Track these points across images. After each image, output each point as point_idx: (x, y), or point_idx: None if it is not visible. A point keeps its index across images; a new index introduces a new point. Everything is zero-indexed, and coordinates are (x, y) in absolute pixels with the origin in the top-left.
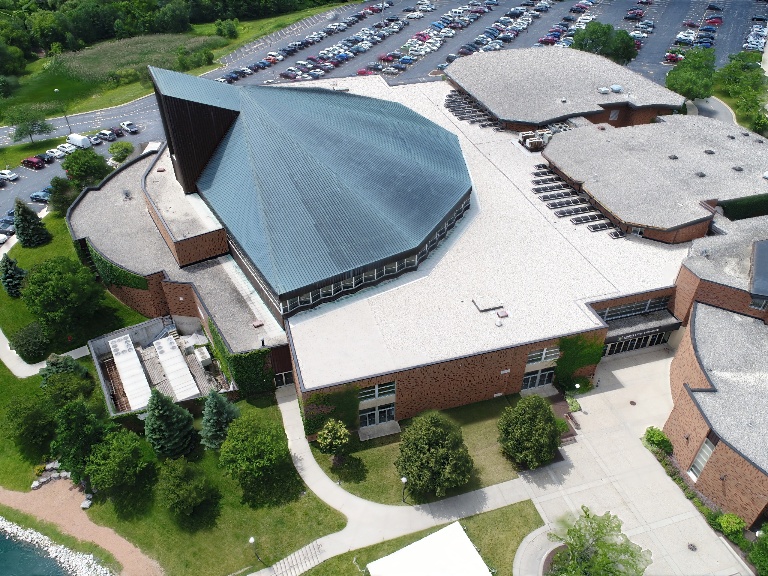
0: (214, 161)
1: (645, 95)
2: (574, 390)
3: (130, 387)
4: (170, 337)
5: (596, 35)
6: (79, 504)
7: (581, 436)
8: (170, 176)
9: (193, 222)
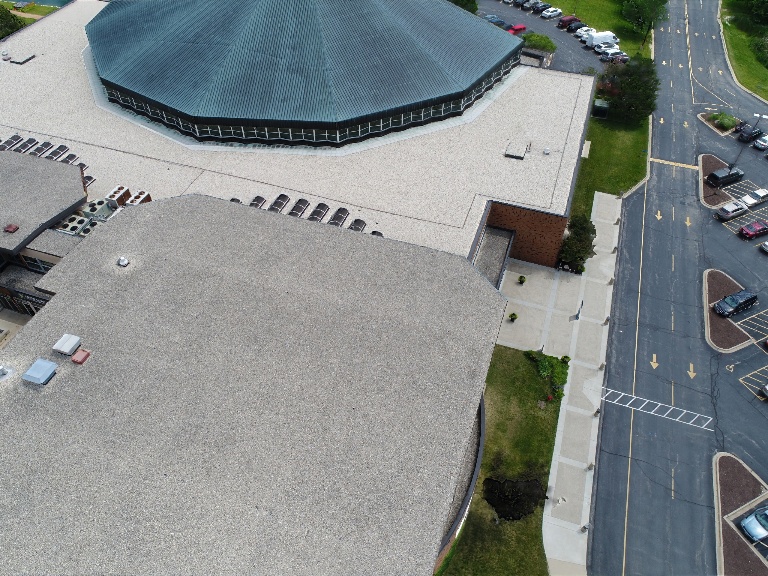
0: None
1: None
2: None
3: None
4: None
5: None
6: None
7: None
8: None
9: None
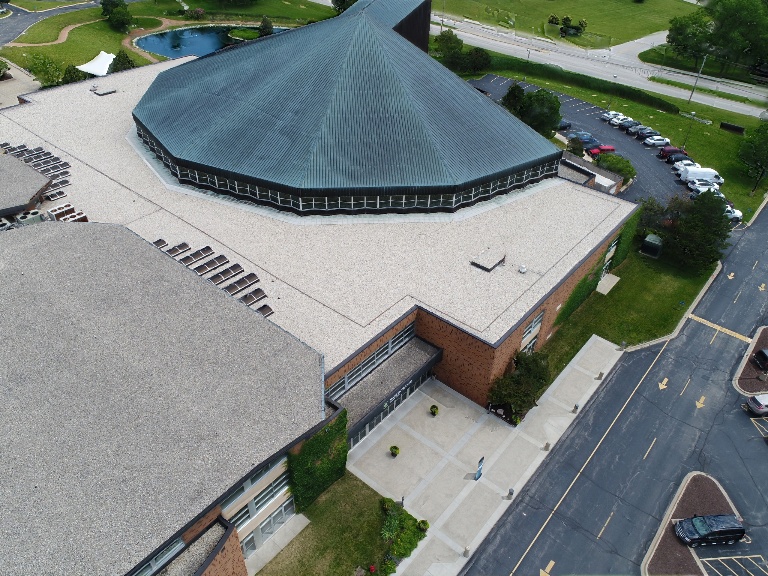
0: None
1: None
2: None
3: None
4: None
5: None
6: None
7: None
8: None
9: None
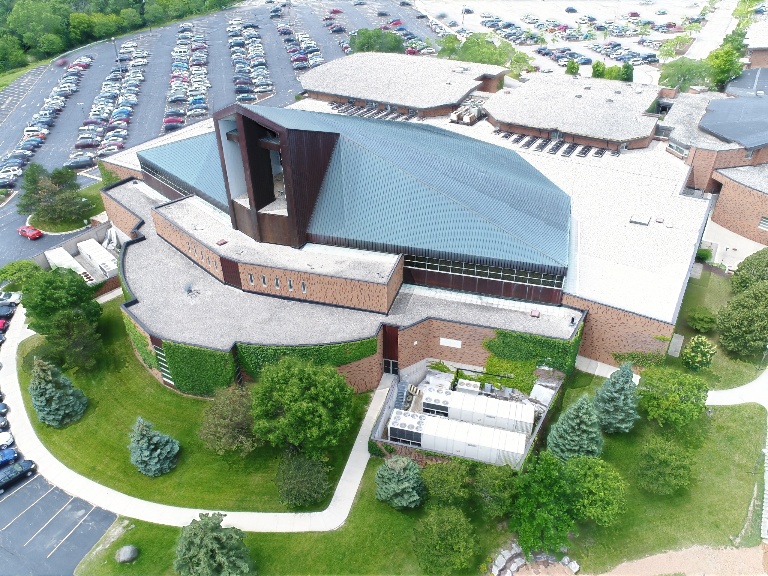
0: (328, 197)
1: (485, 68)
2: (708, 258)
3: (484, 441)
4: (429, 388)
5: (373, 39)
6: (566, 575)
7: None
8: (245, 243)
9: (361, 264)
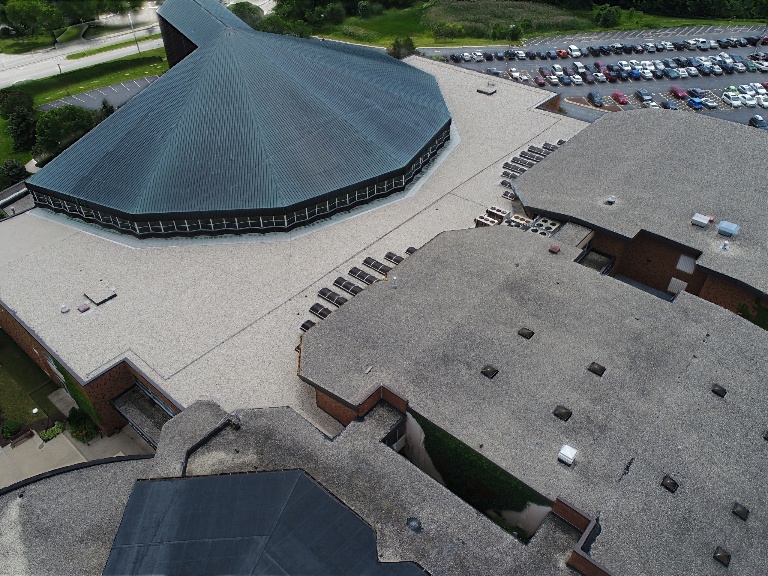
0: None
1: (763, 262)
2: (71, 425)
3: None
4: None
5: None
6: None
7: (1, 451)
8: None
9: None
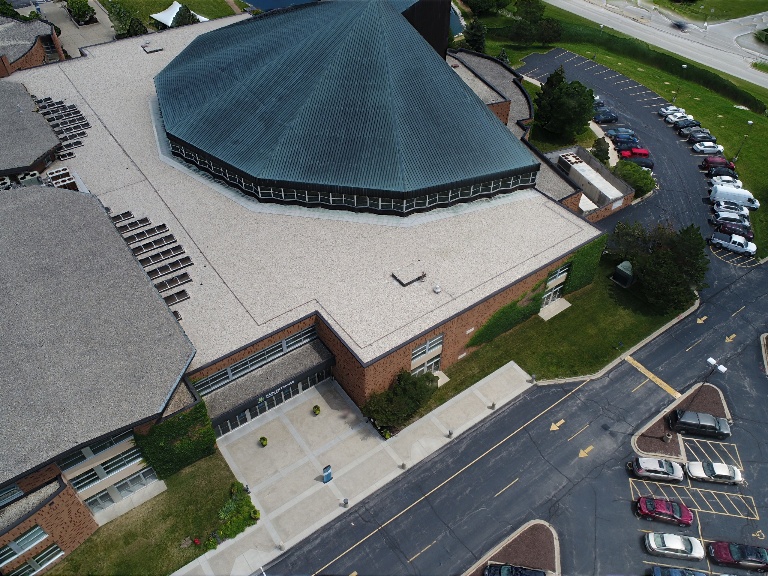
0: None
1: None
2: None
3: None
4: None
5: None
6: None
7: None
8: None
9: None
